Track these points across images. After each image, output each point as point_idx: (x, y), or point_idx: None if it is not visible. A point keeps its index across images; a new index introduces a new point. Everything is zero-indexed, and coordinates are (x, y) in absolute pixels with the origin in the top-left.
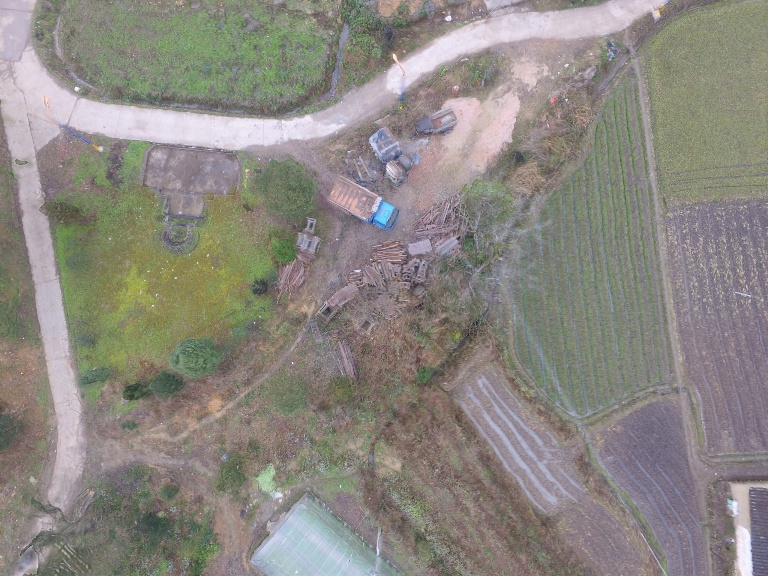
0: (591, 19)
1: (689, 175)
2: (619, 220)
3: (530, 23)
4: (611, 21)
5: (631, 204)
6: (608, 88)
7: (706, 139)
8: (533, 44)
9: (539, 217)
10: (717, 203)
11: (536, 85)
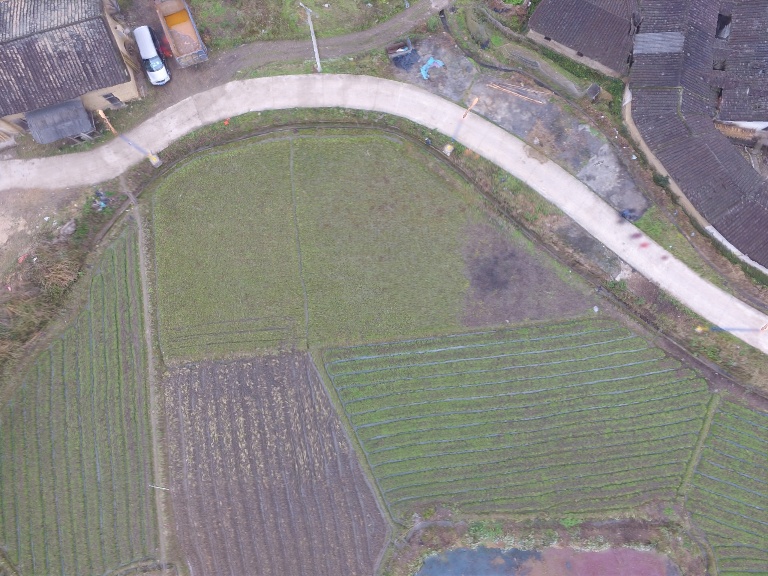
0: (81, 166)
1: (190, 331)
2: (109, 382)
3: (12, 172)
4: (103, 168)
5: (123, 364)
6: (106, 238)
7: (211, 291)
8: (13, 195)
9: (24, 379)
10: (221, 360)
11: (7, 242)
